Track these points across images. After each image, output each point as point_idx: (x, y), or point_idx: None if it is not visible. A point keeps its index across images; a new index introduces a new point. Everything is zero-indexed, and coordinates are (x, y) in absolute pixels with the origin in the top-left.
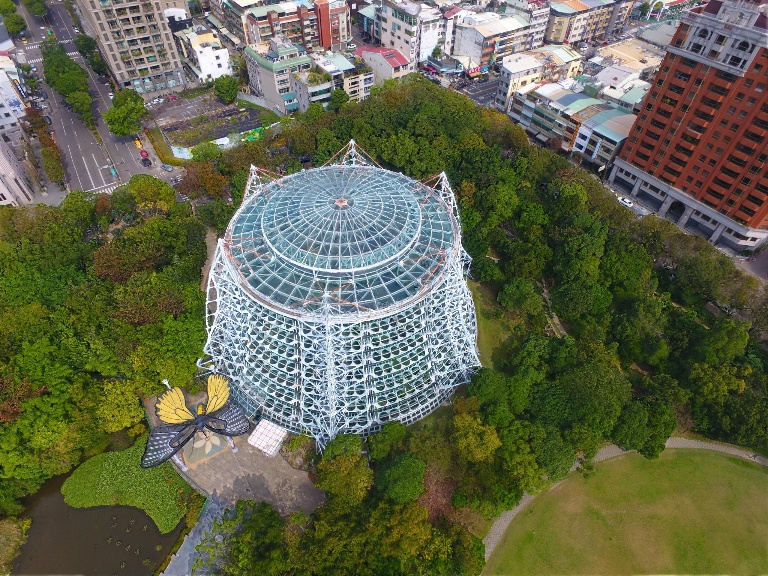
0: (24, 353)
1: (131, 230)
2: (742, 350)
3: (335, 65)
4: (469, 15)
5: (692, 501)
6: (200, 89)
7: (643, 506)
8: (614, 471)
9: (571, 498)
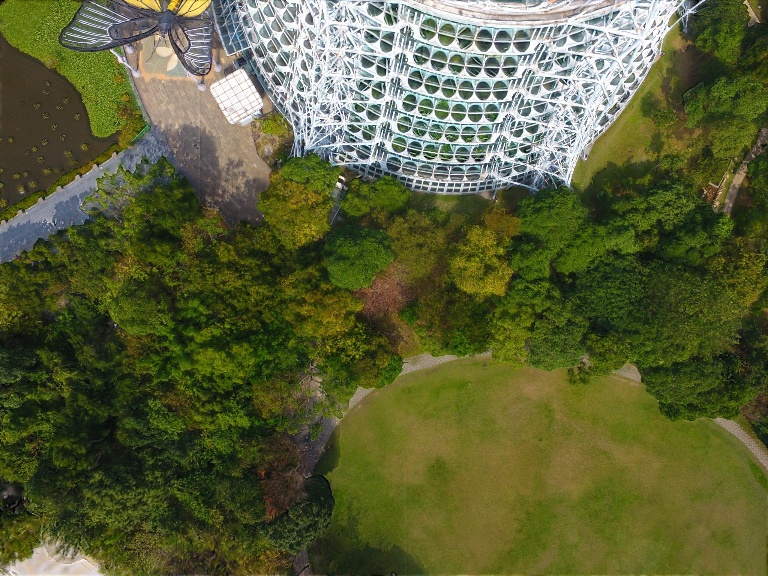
0: None
1: None
2: None
3: None
4: None
5: (662, 468)
6: None
7: (605, 438)
8: (611, 390)
9: (538, 382)
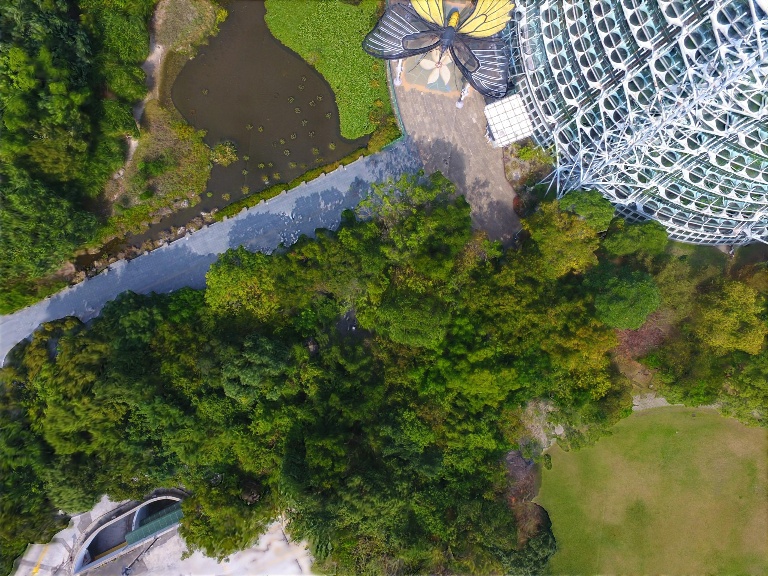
0: None
1: None
2: None
3: None
4: None
5: None
6: None
7: None
8: None
9: (744, 440)
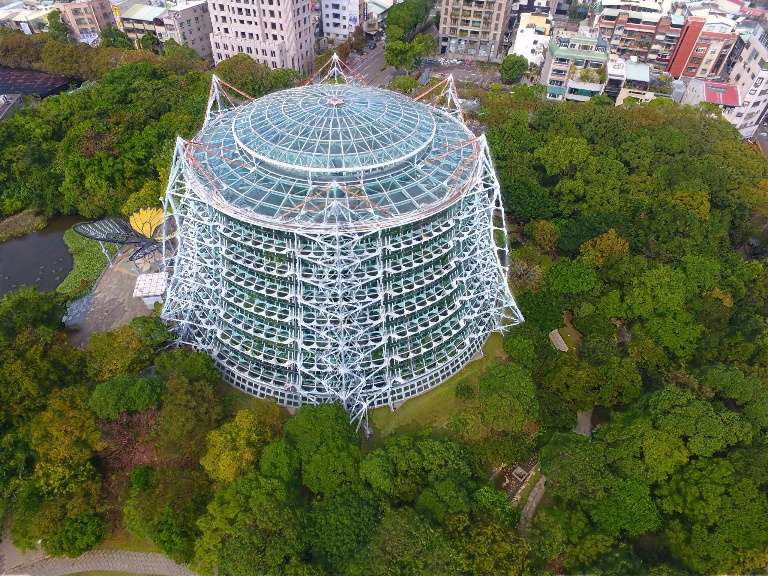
0: (142, 132)
1: None
2: None
3: (626, 71)
4: None
5: None
6: (498, 65)
7: None
8: None
9: None
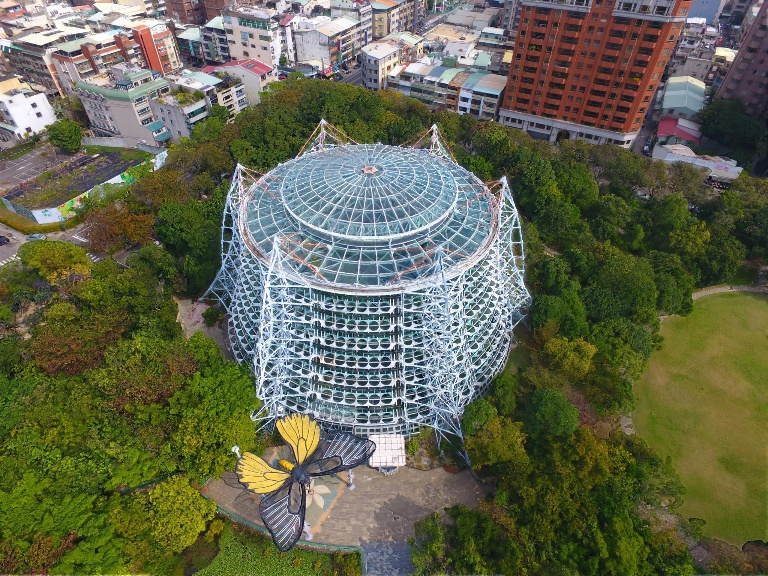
0: (2, 509)
1: (57, 308)
2: (689, 212)
3: (200, 82)
4: (302, 21)
5: (724, 335)
6: (24, 146)
7: (701, 354)
8: None
9: (655, 374)
